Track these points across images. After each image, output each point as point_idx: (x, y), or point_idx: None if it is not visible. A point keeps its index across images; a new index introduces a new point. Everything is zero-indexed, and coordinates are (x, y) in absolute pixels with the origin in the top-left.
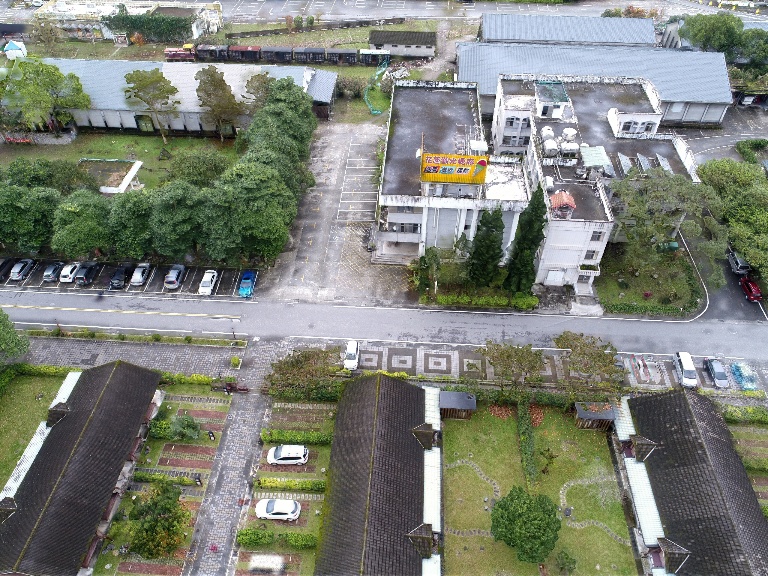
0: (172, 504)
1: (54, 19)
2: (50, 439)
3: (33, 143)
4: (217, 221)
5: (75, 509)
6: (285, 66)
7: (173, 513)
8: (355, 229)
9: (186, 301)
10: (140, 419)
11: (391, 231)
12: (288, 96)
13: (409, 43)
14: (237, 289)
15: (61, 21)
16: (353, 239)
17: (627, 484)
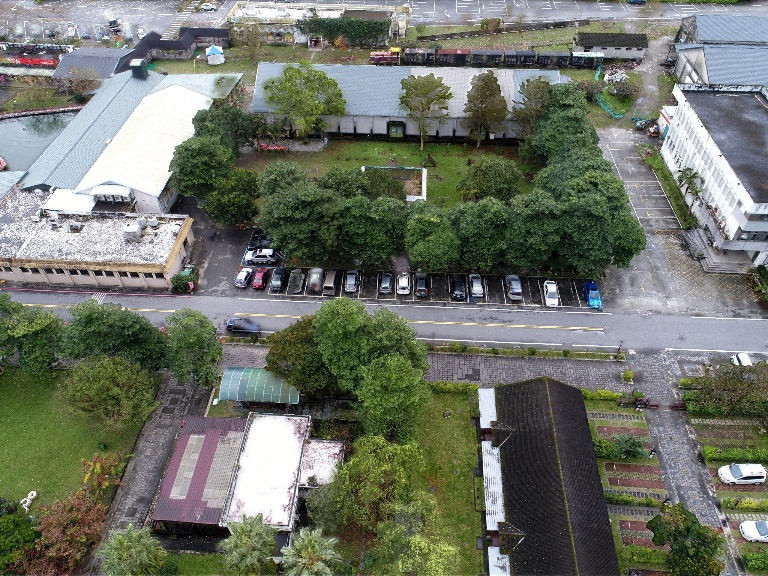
0: (704, 529)
1: (247, 23)
2: (510, 460)
3: (286, 150)
4: (589, 231)
5: (592, 534)
6: (538, 70)
7: (711, 539)
8: (667, 237)
9: (537, 313)
10: (590, 438)
11: (740, 239)
12: (575, 101)
13: (620, 45)
14: (582, 300)
15: (253, 25)
16: (671, 247)
17: None
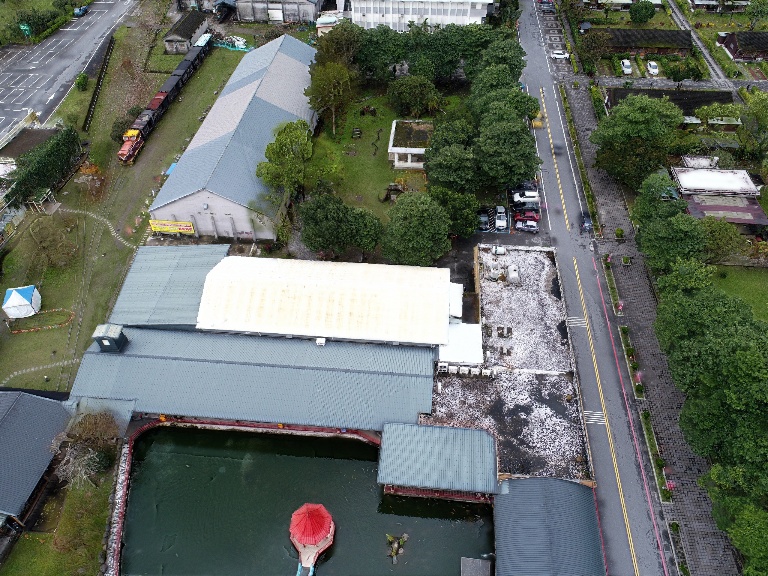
0: None
1: None
2: None
3: None
4: None
5: None
6: (282, 41)
7: None
8: None
9: None
10: None
11: None
12: None
13: (199, 24)
14: None
15: None
16: None
17: (603, 10)
